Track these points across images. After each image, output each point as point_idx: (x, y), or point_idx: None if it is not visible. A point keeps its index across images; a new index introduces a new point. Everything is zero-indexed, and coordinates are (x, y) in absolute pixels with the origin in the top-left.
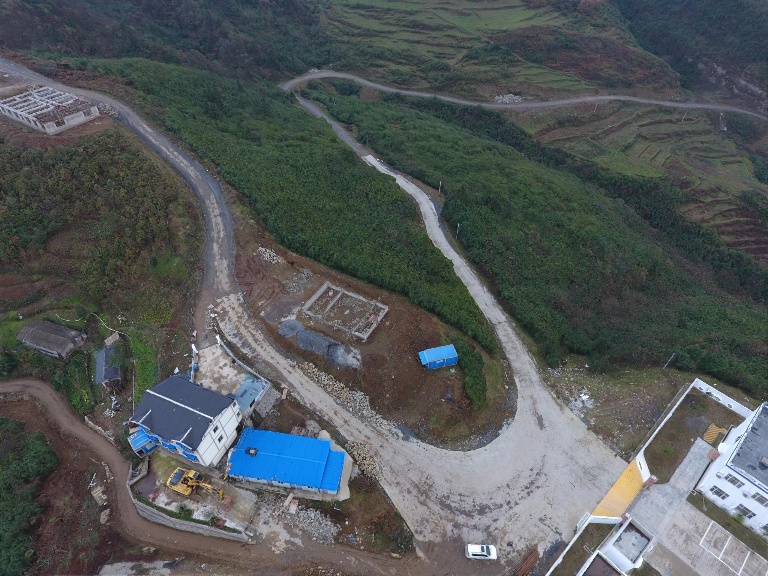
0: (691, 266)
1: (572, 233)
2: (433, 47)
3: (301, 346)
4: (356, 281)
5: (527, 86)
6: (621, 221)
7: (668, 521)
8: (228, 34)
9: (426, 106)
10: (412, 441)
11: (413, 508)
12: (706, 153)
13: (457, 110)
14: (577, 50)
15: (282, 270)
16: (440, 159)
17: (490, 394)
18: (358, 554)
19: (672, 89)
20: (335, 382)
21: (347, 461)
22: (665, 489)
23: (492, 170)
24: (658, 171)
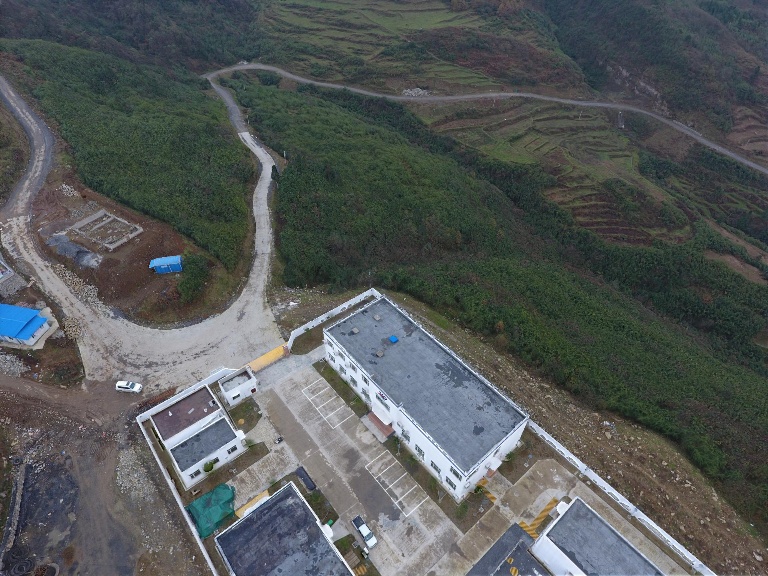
0: (536, 240)
1: (407, 202)
2: (354, 44)
3: (57, 252)
4: (130, 211)
5: (433, 81)
6: (477, 199)
7: (288, 377)
8: (159, 26)
9: (336, 96)
10: (119, 319)
11: (95, 360)
12: (596, 147)
13: (363, 101)
14: (487, 50)
15: (74, 201)
16: (315, 138)
17: (213, 297)
18: (35, 384)
19: (575, 88)
20: (76, 278)
21: (54, 327)
22: (301, 358)
23: (362, 150)
24: (534, 159)
